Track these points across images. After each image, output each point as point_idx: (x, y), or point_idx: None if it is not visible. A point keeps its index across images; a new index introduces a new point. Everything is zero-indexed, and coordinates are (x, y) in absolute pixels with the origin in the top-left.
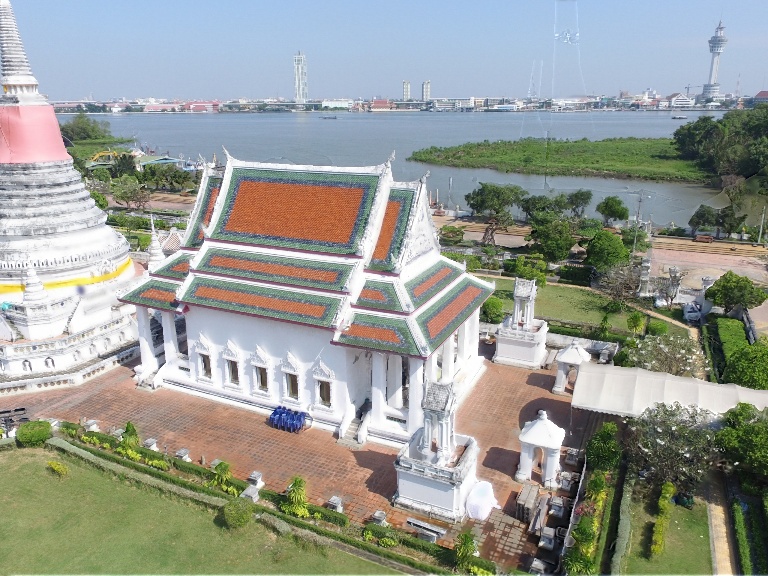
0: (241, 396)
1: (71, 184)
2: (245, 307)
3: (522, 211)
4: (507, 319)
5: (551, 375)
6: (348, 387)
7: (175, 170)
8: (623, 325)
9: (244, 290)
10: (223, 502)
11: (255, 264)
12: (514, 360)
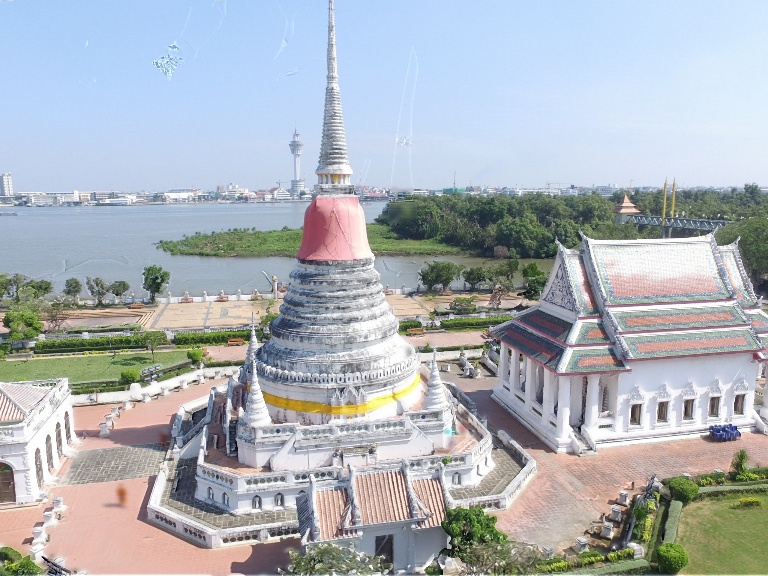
0: (672, 430)
1: None
2: (690, 351)
3: (460, 282)
4: None
5: None
6: None
7: (25, 280)
8: None
9: (675, 339)
10: None
11: (665, 318)
12: None
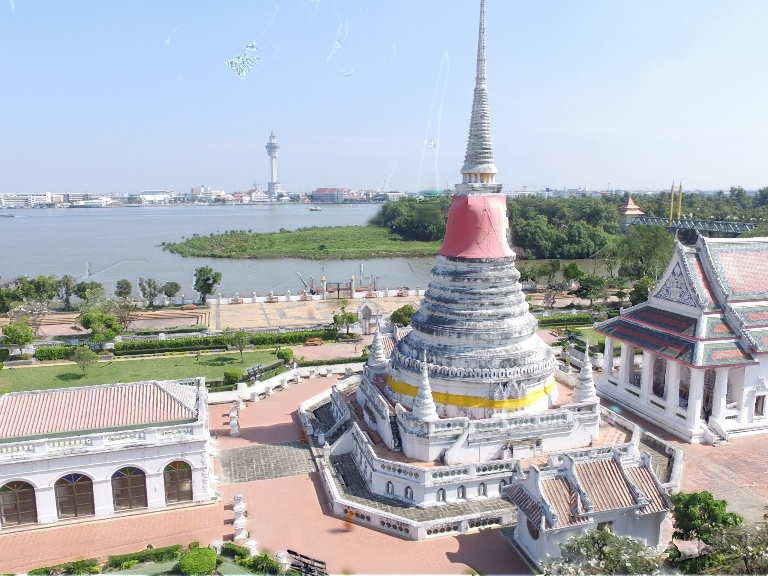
0: None
1: None
2: None
3: None
4: None
5: None
6: None
7: (76, 282)
8: None
9: None
10: None
11: None
12: None
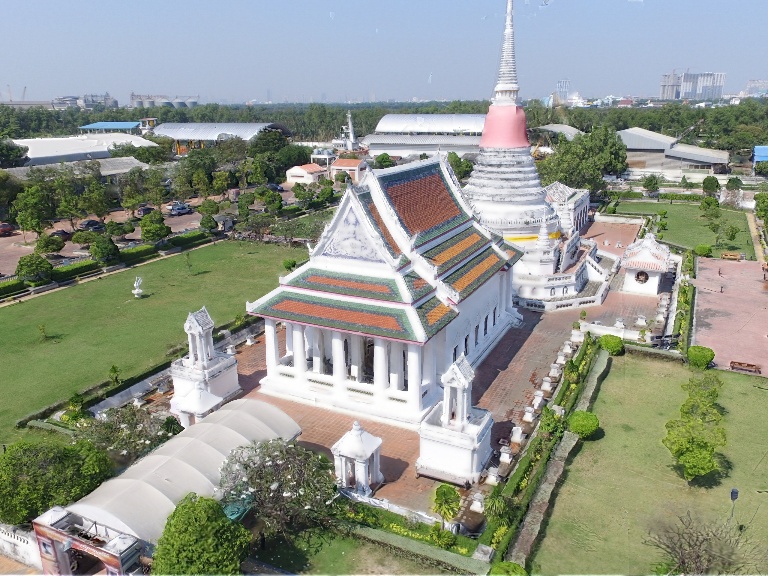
0: None
1: (503, 167)
2: None
3: None
4: (482, 411)
5: (401, 476)
6: (306, 332)
7: None
8: None
9: None
10: (217, 326)
11: None
12: None
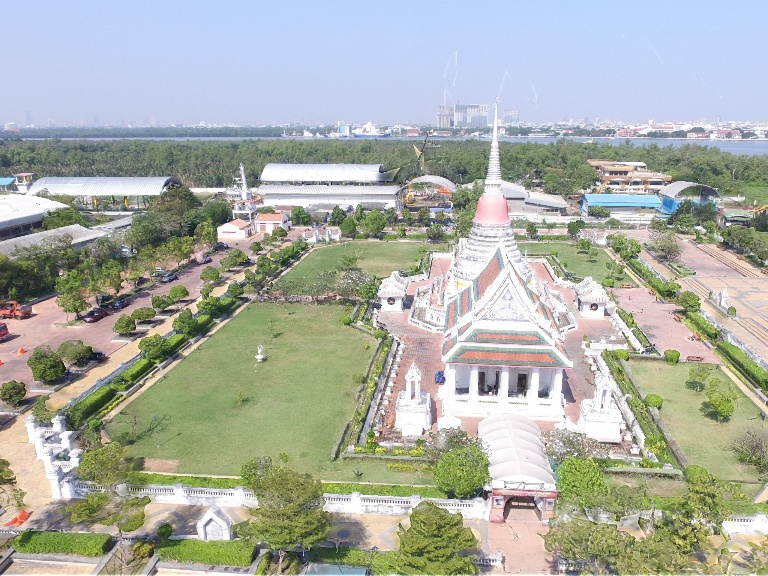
0: None
1: (497, 237)
2: None
3: None
4: None
5: None
6: None
7: (745, 234)
8: (716, 467)
9: None
10: (364, 375)
11: None
12: (581, 426)
